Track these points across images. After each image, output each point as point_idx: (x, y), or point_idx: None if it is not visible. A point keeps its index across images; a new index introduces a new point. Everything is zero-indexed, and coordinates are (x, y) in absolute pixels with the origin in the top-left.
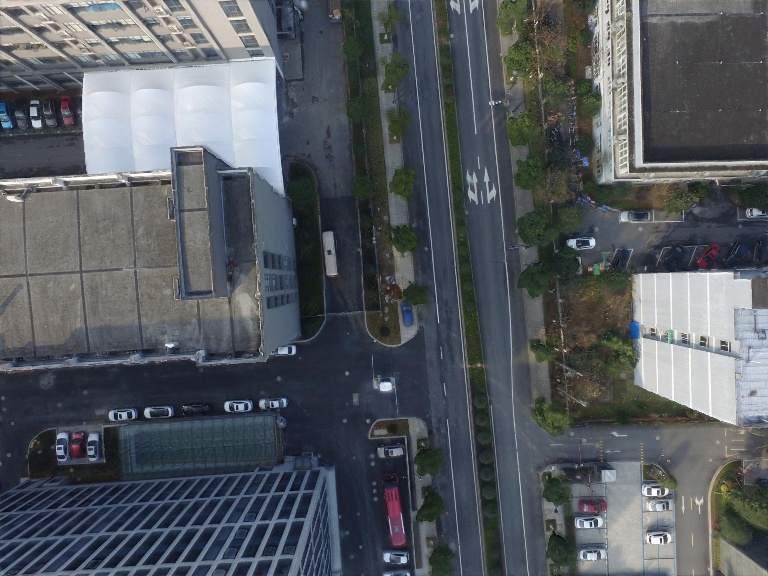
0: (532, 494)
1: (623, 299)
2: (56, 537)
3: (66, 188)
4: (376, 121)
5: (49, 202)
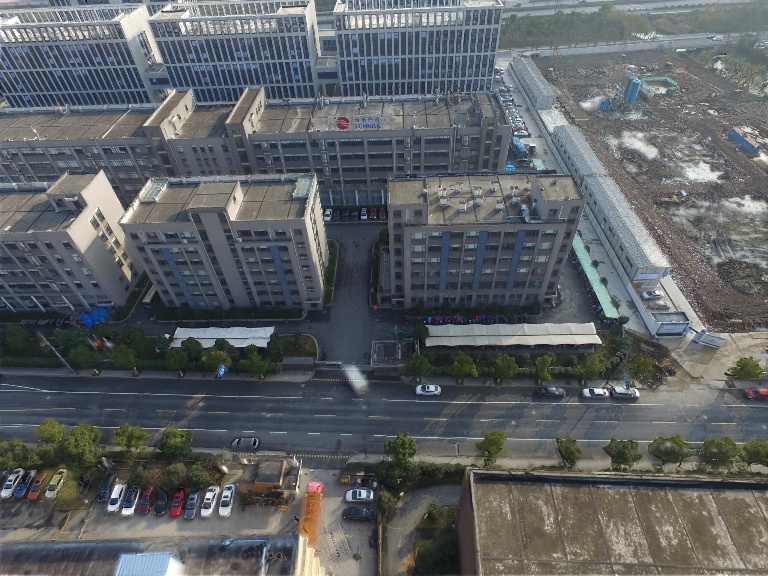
0: None
1: None
2: None
3: None
4: None
5: None
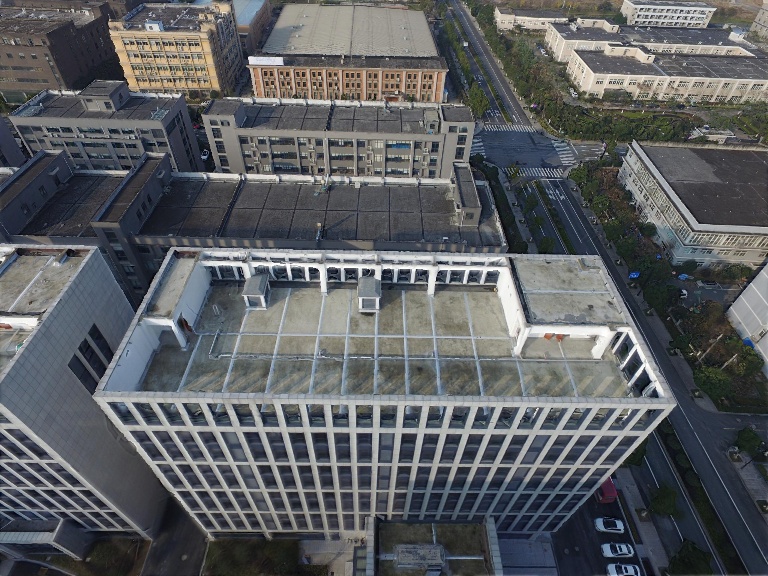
0: (728, 473)
1: (726, 329)
2: None
3: (383, 186)
4: (518, 232)
5: (374, 189)
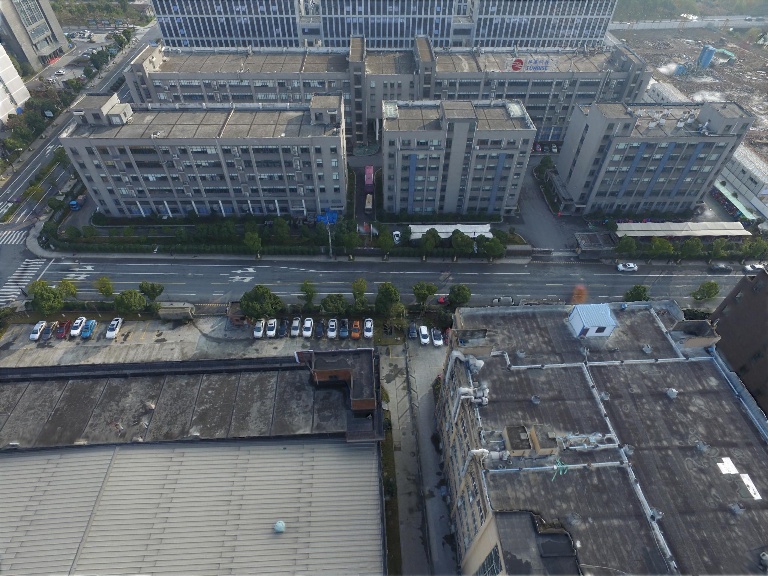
0: None
1: None
2: None
3: None
4: None
5: None
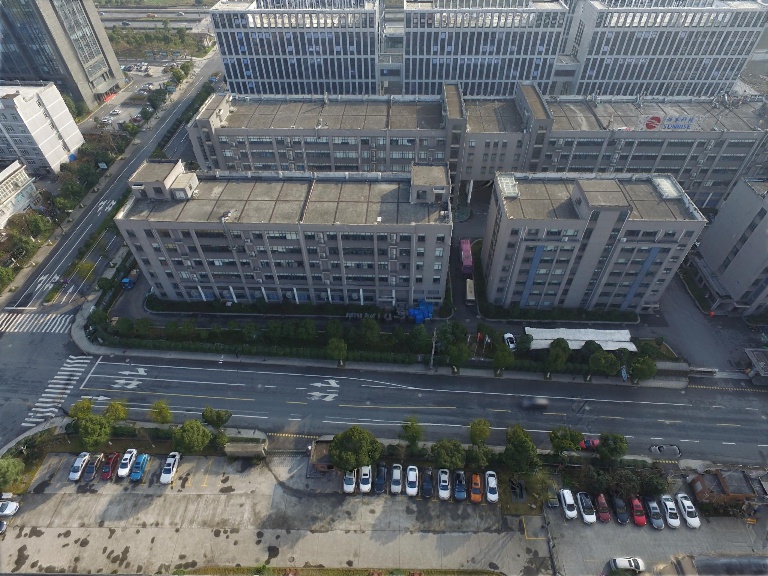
0: (159, 125)
1: None
2: (320, 81)
3: None
4: None
5: None
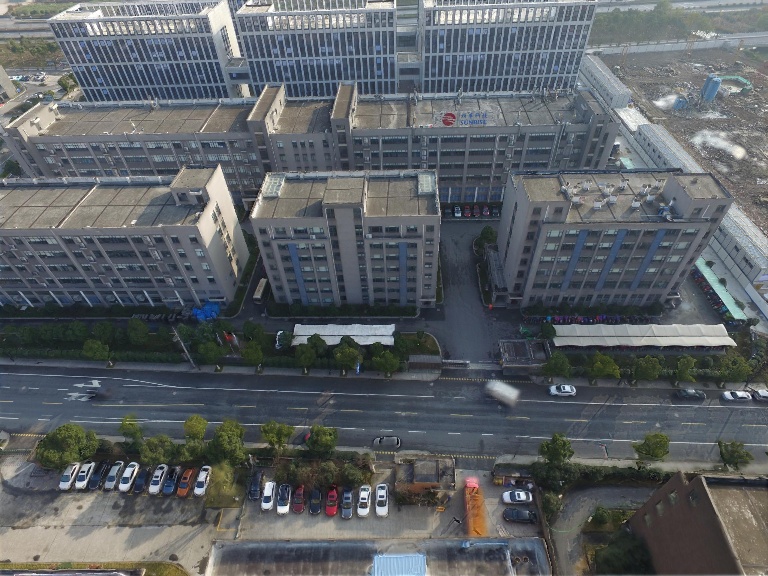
0: None
1: None
2: (171, 86)
3: None
4: None
5: None
